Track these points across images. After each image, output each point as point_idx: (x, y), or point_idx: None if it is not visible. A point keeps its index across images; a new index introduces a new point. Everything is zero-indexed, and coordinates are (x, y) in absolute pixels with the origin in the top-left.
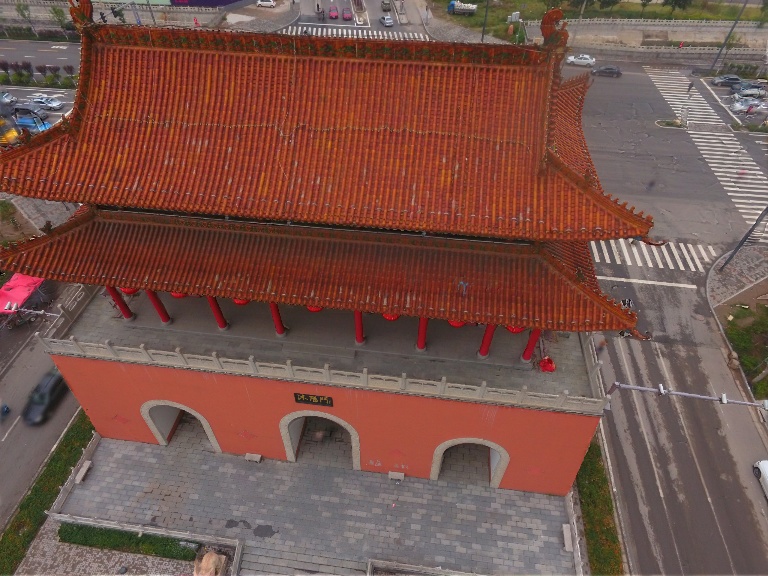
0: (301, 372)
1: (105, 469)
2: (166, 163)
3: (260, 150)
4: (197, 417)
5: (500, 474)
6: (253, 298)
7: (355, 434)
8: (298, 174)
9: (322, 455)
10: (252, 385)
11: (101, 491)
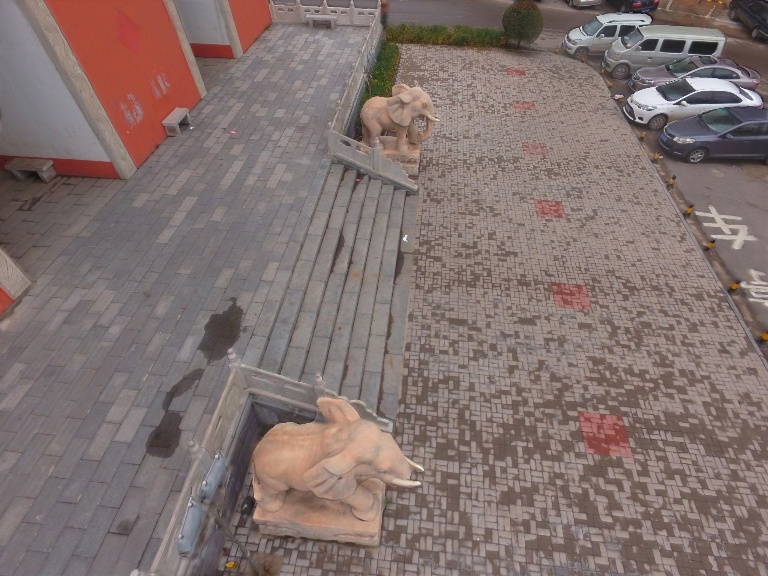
0: None
1: None
2: None
3: None
4: None
5: (226, 3)
6: None
7: None
8: None
9: (51, 230)
10: None
11: None
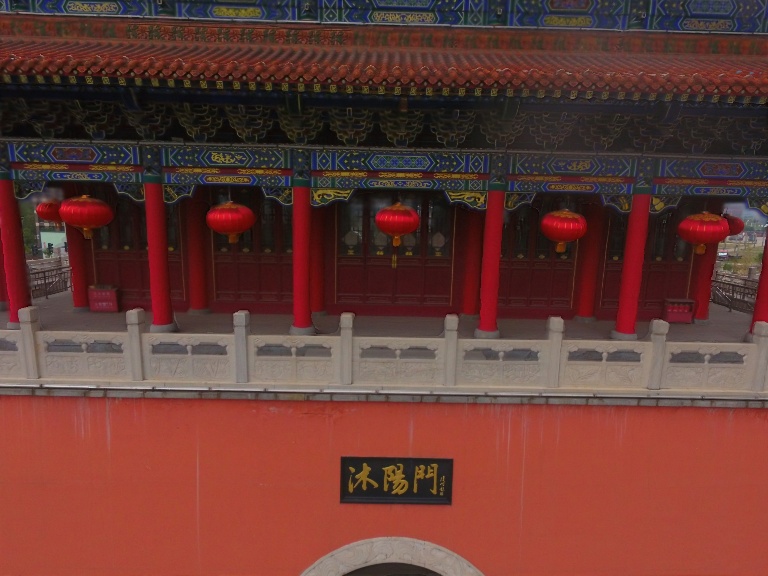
0: (374, 360)
1: None
2: None
3: None
4: None
5: None
6: (292, 72)
7: None
8: None
9: None
10: (219, 441)
11: None
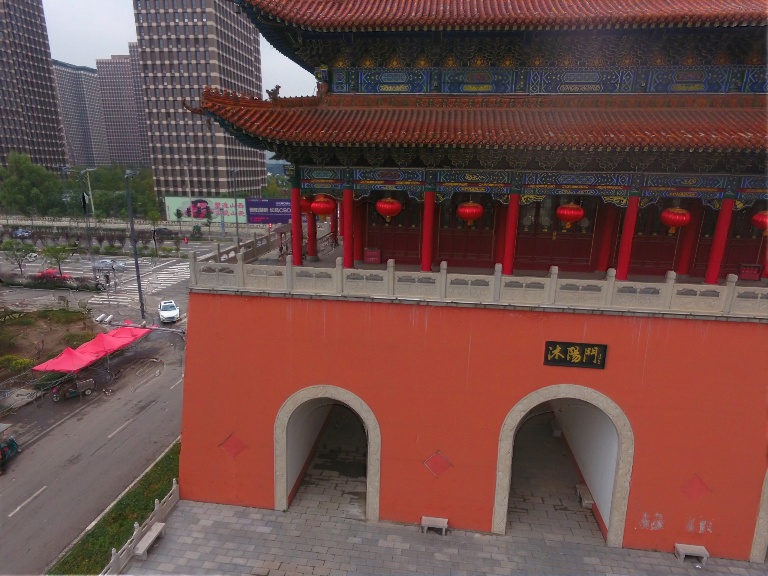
0: (567, 291)
1: (184, 540)
2: (442, 8)
3: (542, 0)
4: (366, 423)
5: None
6: (536, 140)
7: (629, 439)
8: (593, 7)
9: (544, 526)
10: (482, 330)
11: (177, 571)
